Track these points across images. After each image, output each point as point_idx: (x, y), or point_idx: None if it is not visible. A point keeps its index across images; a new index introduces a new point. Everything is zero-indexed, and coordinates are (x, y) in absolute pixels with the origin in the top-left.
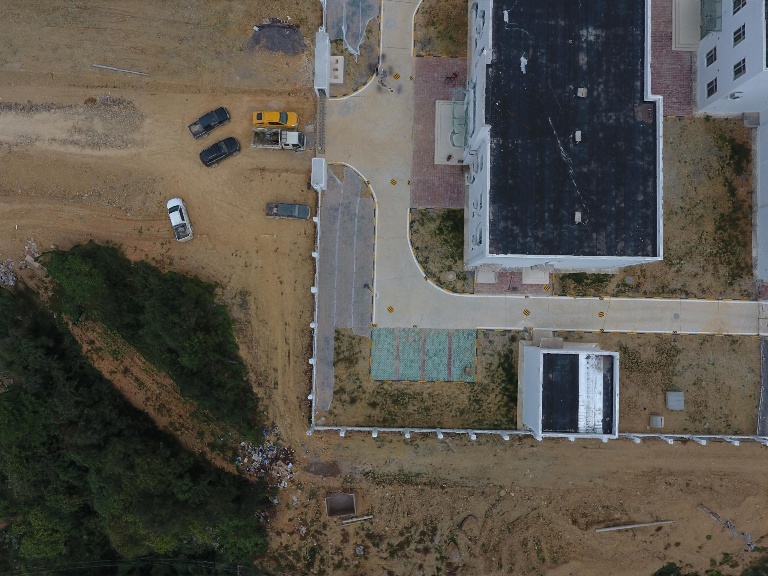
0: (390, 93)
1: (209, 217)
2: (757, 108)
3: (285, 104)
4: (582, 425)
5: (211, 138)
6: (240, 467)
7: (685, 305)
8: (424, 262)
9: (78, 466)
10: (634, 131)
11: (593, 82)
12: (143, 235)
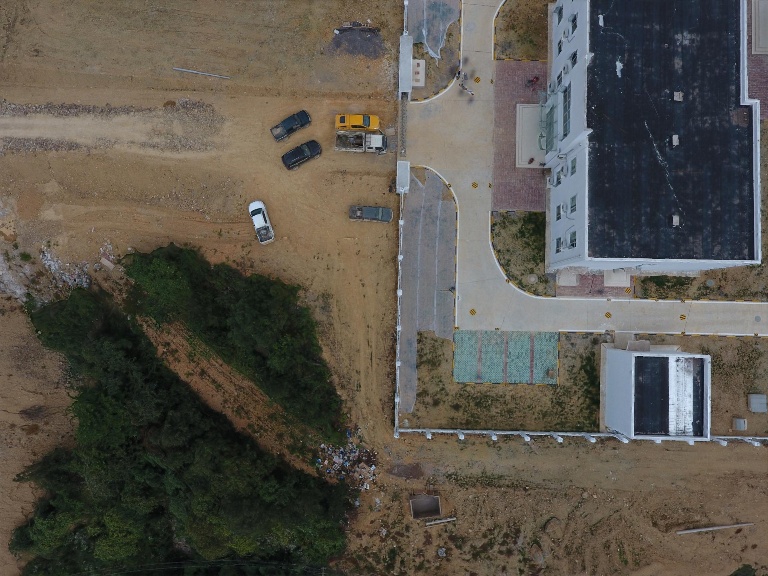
0: (471, 96)
1: (290, 220)
2: None
3: (365, 107)
4: (672, 428)
5: (291, 141)
6: (320, 469)
7: (766, 308)
8: (506, 265)
9: (154, 468)
10: (730, 135)
11: (688, 86)
12: (222, 238)
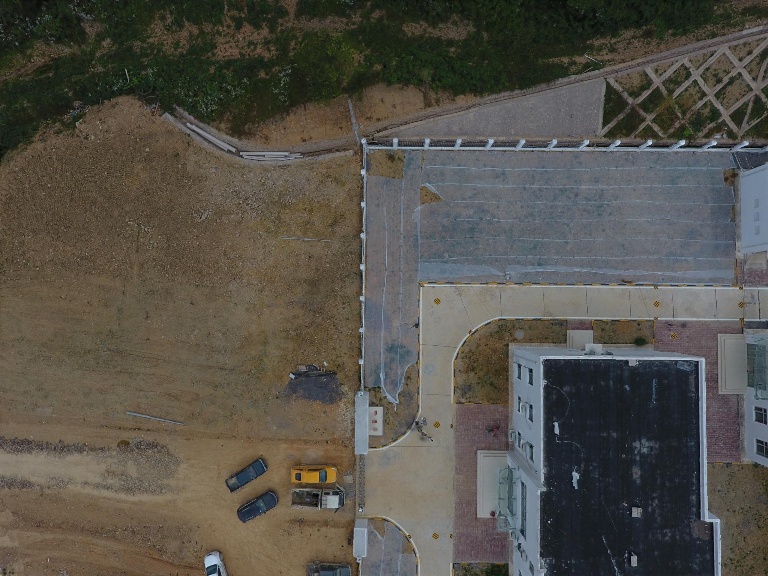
0: (430, 442)
1: (247, 569)
2: None
3: (323, 452)
4: None
5: (248, 486)
6: None
7: None
8: None
9: None
10: (690, 548)
11: (647, 497)
12: None
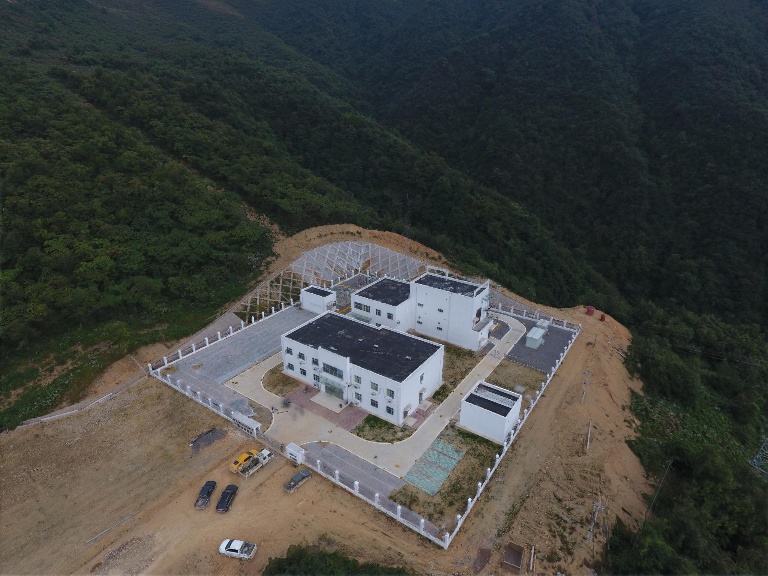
0: (287, 412)
1: (254, 533)
2: (408, 327)
3: None
4: (510, 407)
5: (212, 502)
6: None
7: (475, 371)
8: (383, 440)
9: None
10: (388, 336)
11: None
12: None
